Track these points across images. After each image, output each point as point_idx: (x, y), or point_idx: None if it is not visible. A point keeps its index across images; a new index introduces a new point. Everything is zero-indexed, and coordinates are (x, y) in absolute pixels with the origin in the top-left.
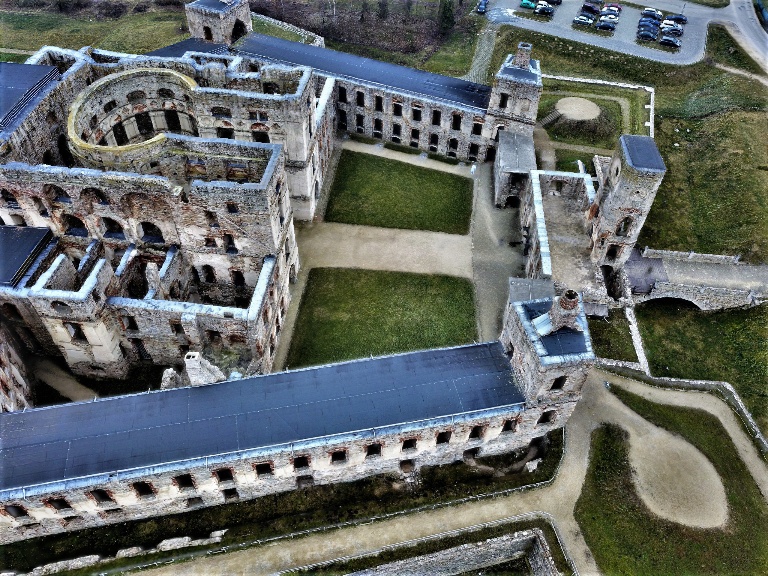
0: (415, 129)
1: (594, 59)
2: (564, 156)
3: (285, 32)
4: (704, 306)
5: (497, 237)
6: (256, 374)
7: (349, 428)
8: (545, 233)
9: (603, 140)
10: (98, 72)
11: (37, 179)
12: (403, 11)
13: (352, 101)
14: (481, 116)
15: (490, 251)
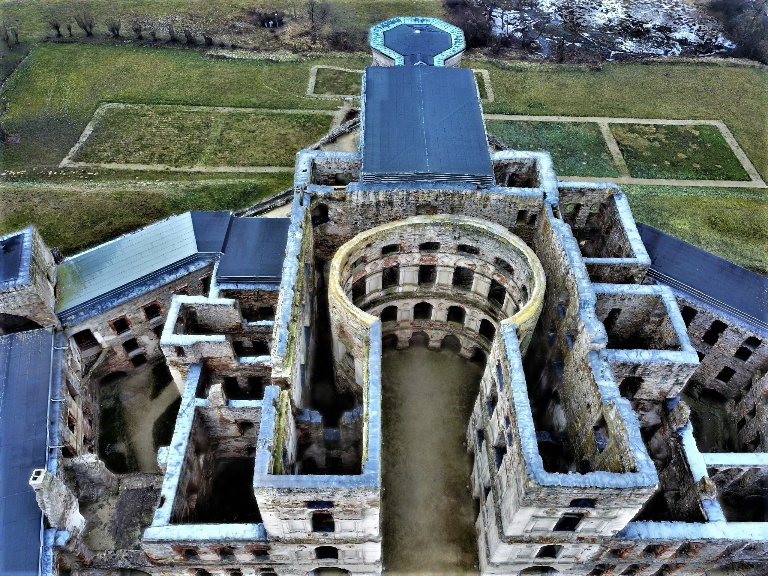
0: None
1: None
2: None
3: None
4: None
5: None
6: (127, 563)
7: None
8: None
9: None
10: (544, 214)
11: None
12: None
13: None
14: None
15: None
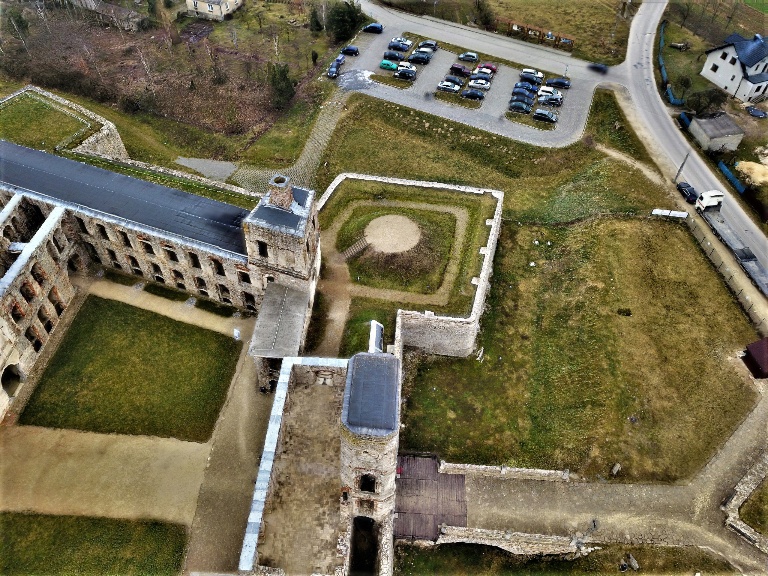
0: (175, 270)
1: (452, 140)
2: (361, 309)
3: (67, 118)
4: (516, 550)
5: (246, 445)
6: None
7: None
8: (265, 483)
9: (420, 279)
10: None
11: None
12: (245, 74)
13: (94, 234)
14: (243, 264)
15: (229, 472)
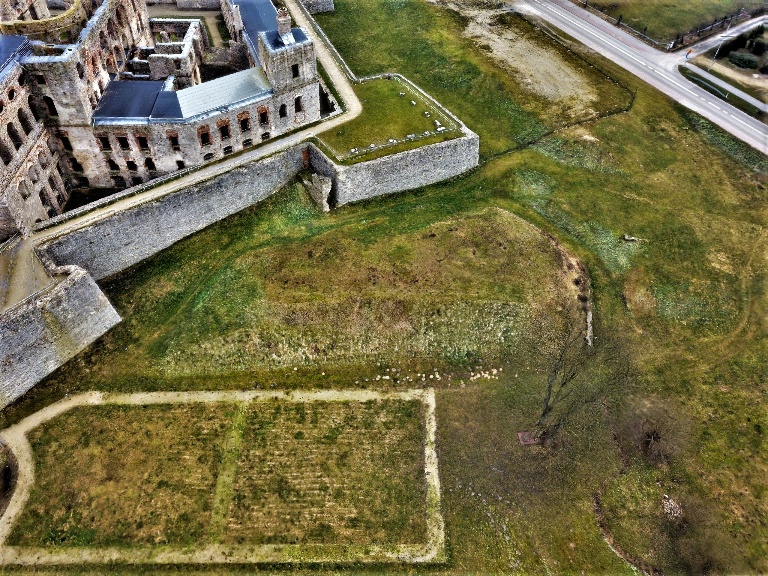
0: None
1: None
2: None
3: None
4: None
5: None
6: None
7: None
8: None
9: None
10: None
11: (96, 32)
12: None
13: None
14: None
15: None
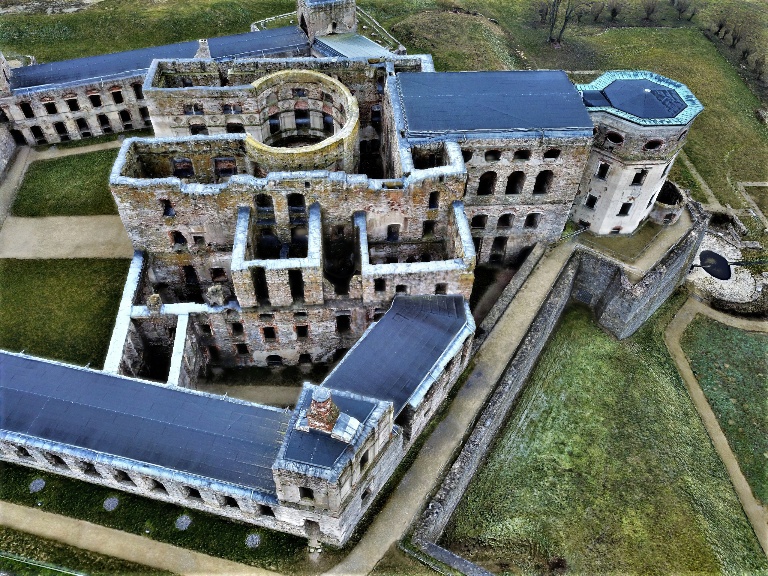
0: None
1: None
2: None
3: None
4: None
5: None
6: None
7: (120, 53)
8: None
9: None
10: None
11: None
12: None
13: None
14: None
15: None
